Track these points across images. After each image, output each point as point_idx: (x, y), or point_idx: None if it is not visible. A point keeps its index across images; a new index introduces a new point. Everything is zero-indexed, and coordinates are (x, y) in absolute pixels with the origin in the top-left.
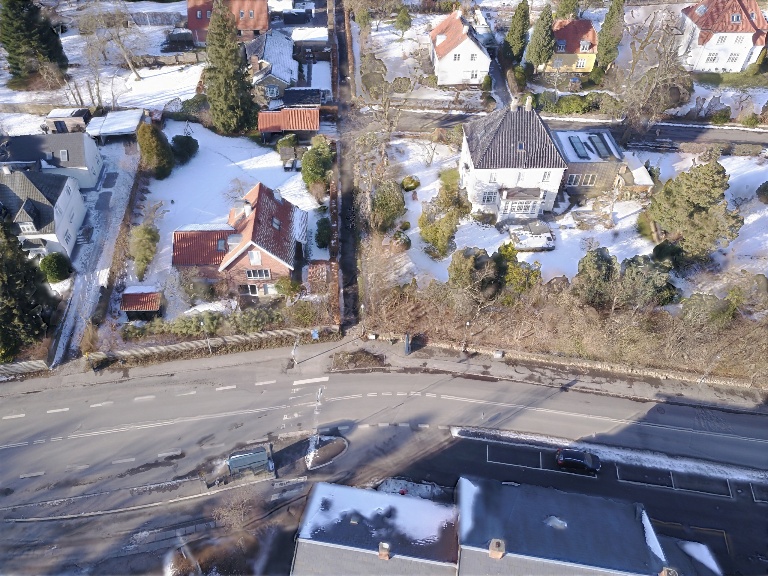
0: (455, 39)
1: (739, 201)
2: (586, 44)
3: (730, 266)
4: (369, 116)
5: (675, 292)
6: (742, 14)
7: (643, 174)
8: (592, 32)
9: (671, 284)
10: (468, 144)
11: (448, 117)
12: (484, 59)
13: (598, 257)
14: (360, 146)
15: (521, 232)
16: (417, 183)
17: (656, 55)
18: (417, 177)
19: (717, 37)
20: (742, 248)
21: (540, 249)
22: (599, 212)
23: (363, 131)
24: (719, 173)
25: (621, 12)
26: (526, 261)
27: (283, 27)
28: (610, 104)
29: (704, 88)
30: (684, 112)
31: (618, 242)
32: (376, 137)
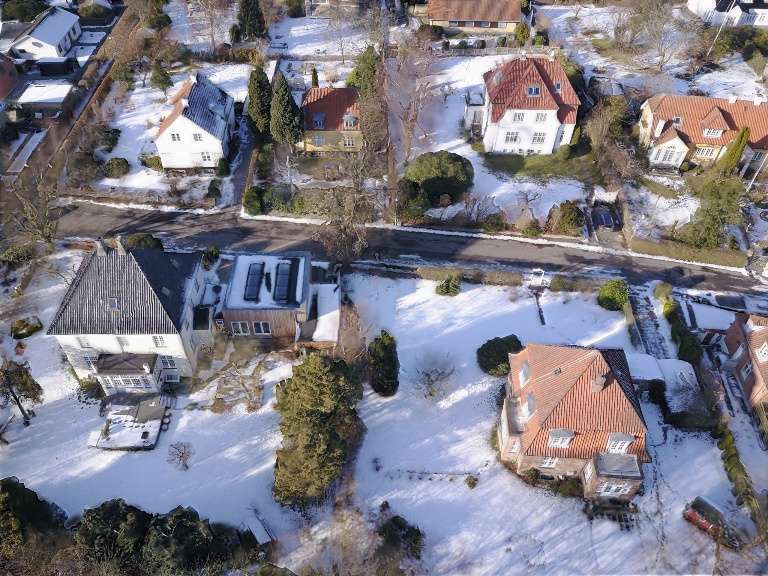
0: (175, 114)
1: (434, 375)
2: (347, 120)
3: (372, 493)
4: (54, 213)
5: (257, 550)
6: (542, 86)
7: (330, 323)
8: (359, 104)
9: (254, 536)
10: (68, 289)
11: (153, 215)
12: (212, 139)
13: (99, 520)
14: (5, 262)
15: (120, 418)
16: (32, 328)
17: (458, 127)
18: (36, 319)
19: (512, 114)
20: (410, 456)
21: (134, 448)
22: (254, 380)
23: (30, 236)
24: (385, 347)
25: (375, 85)
26: (106, 468)
27: (37, 79)
28: (350, 206)
29: (496, 177)
30: (454, 214)
31: (246, 439)
32: (27, 251)
